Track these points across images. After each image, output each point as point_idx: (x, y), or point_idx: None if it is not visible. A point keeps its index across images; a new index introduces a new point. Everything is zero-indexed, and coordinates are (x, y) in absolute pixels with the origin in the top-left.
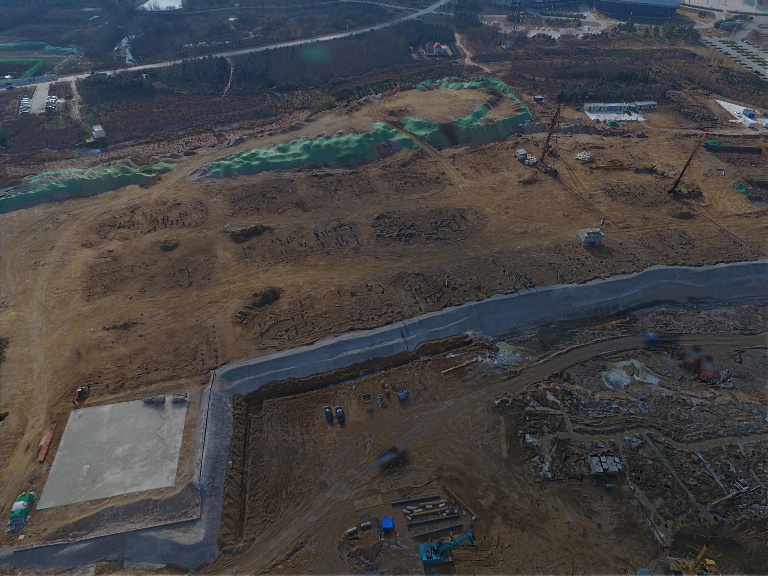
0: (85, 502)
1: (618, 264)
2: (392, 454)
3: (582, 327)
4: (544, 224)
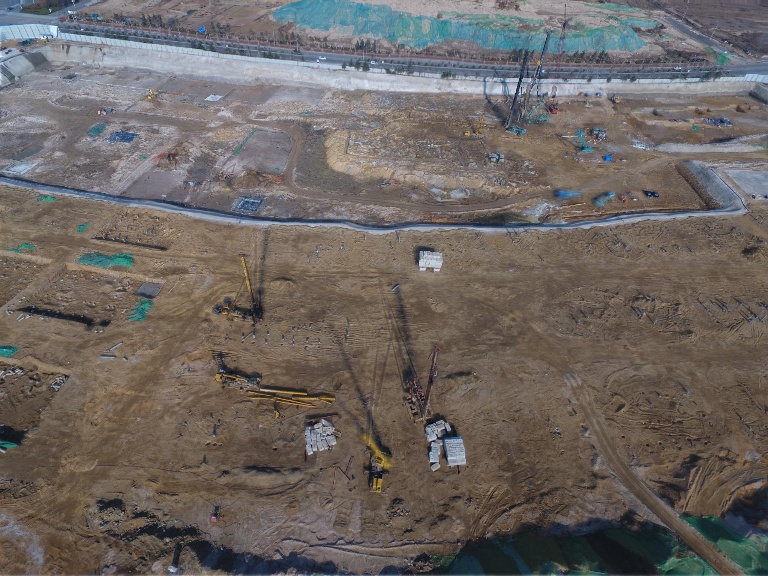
0: (761, 170)
1: (415, 240)
2: (611, 178)
3: (466, 223)
4: (470, 295)
